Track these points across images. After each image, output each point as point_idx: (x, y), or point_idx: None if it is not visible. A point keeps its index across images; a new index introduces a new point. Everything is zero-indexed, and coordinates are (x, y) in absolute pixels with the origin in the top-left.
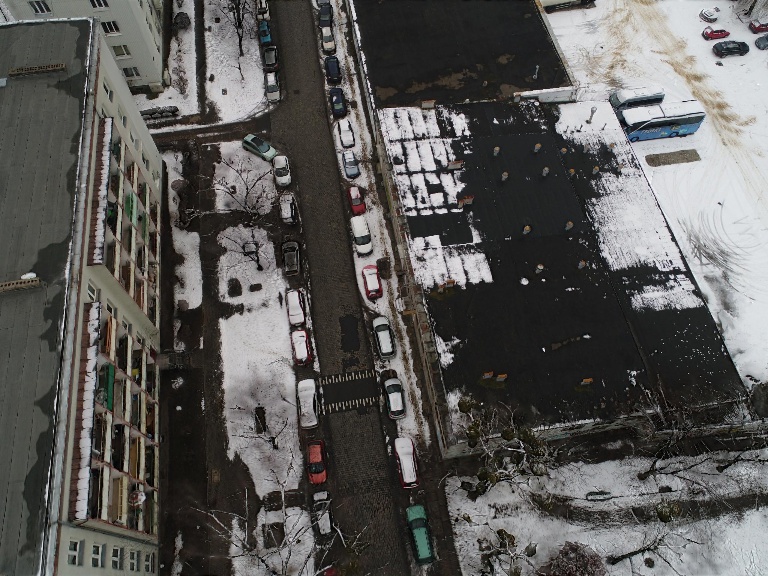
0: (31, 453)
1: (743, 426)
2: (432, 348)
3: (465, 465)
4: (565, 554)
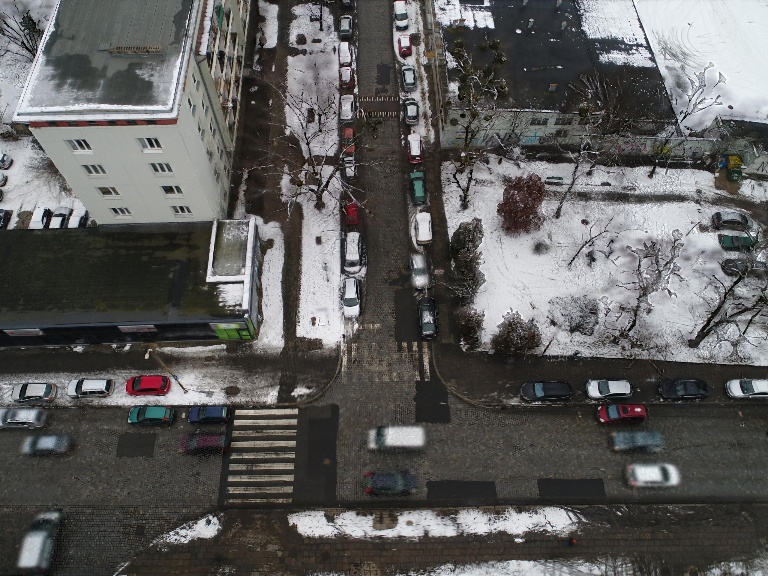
0: (178, 5)
1: (671, 142)
2: (442, 57)
3: None
4: None
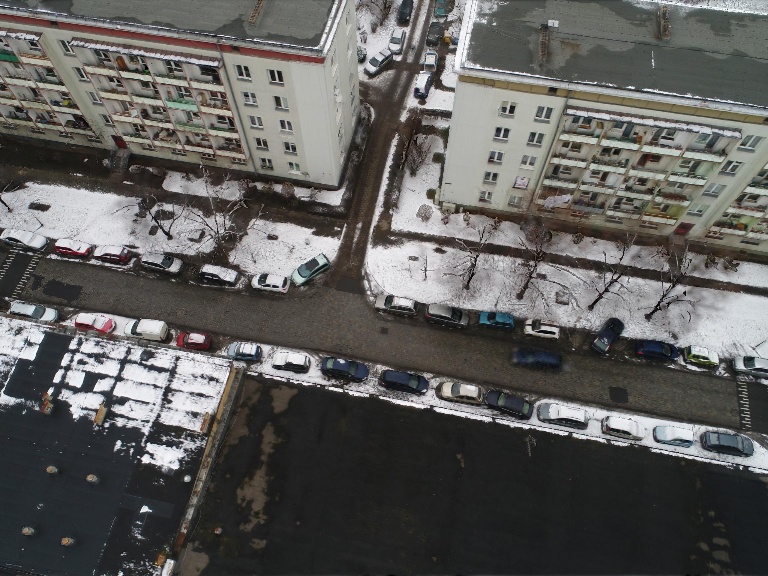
0: None
1: None
2: None
3: None
4: None
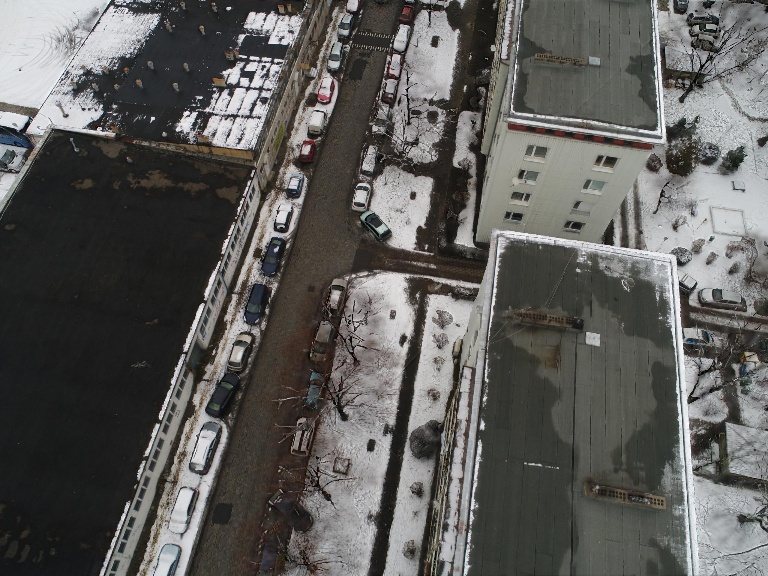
0: None
1: None
2: None
3: None
4: None
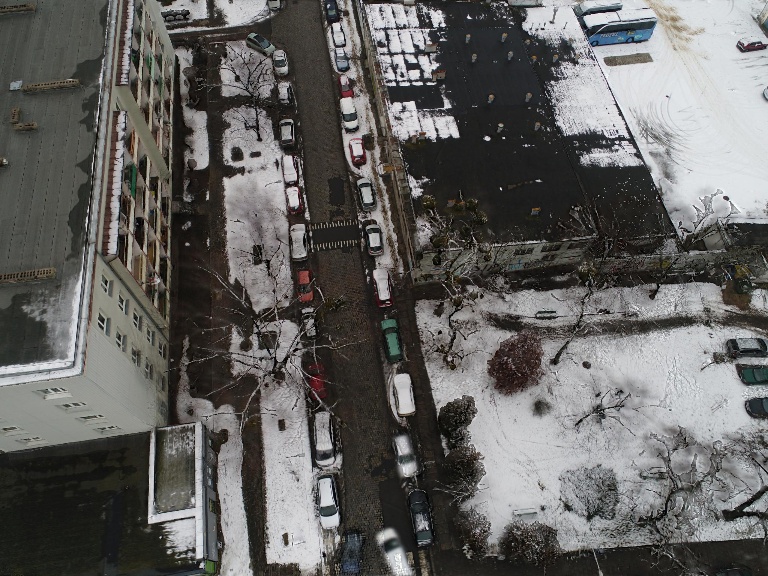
0: (74, 197)
1: (671, 258)
2: (405, 184)
3: (433, 291)
4: (510, 338)
